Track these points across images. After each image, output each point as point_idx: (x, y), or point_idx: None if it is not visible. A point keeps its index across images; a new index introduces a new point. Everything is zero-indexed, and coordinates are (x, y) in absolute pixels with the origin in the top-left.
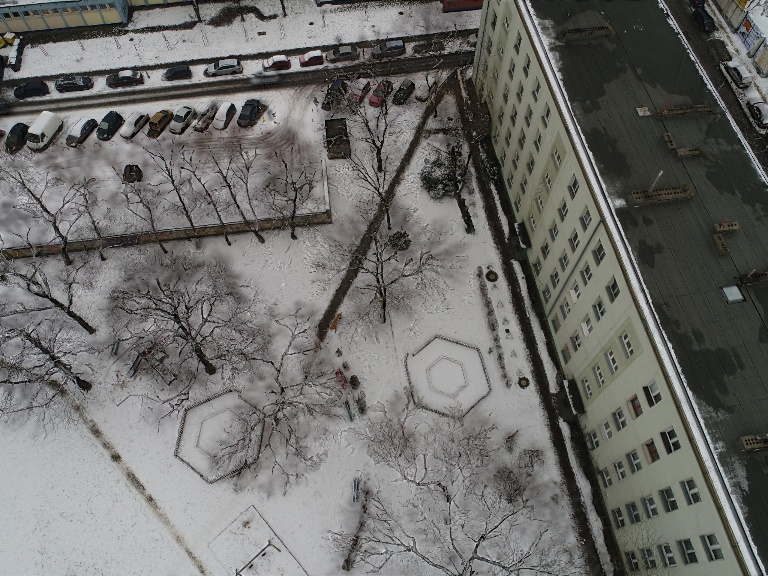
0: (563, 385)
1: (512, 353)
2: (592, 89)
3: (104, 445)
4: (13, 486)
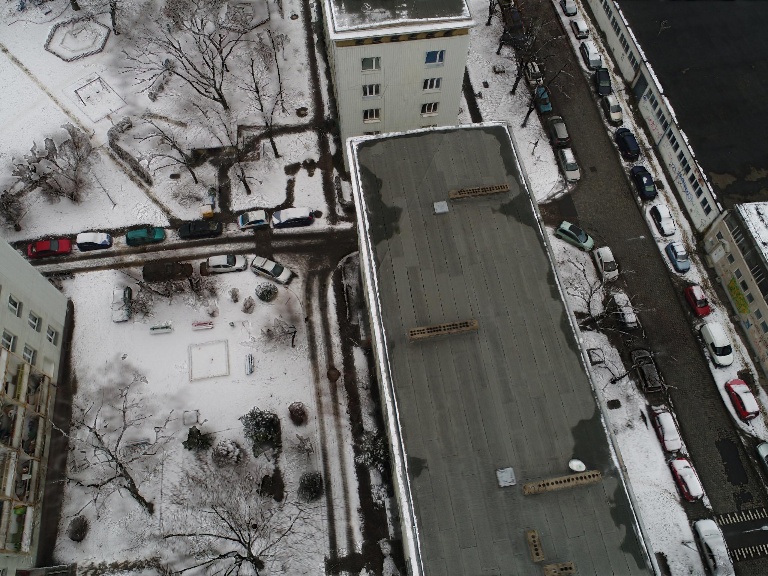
0: (313, 6)
1: (290, 2)
2: None
3: None
4: None
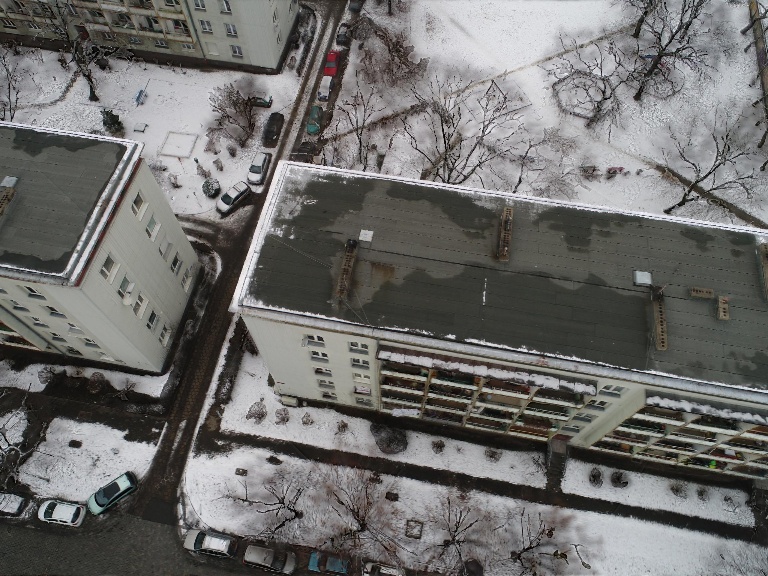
0: None
1: None
2: None
3: (591, 41)
4: (574, 3)
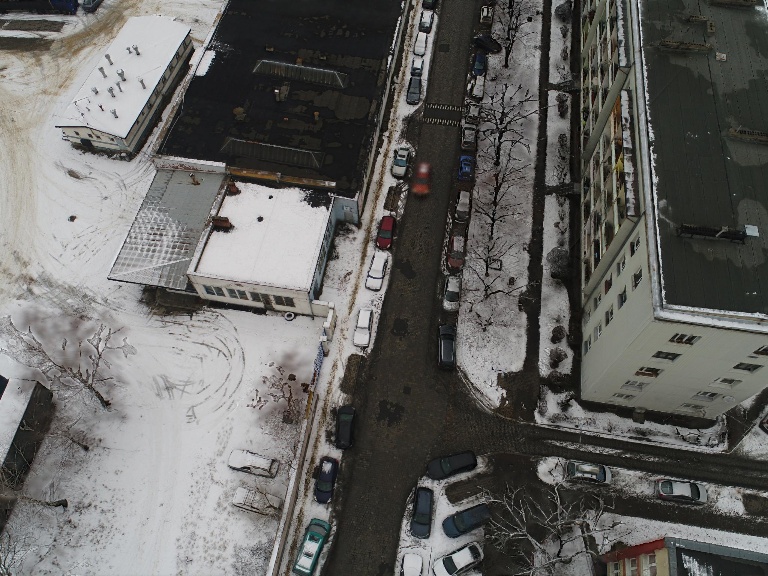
0: None
1: None
2: (761, 87)
3: None
4: None
